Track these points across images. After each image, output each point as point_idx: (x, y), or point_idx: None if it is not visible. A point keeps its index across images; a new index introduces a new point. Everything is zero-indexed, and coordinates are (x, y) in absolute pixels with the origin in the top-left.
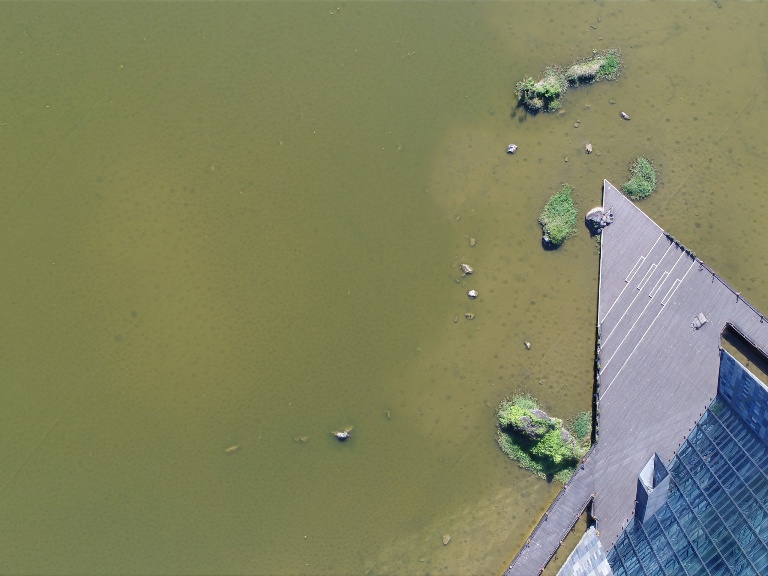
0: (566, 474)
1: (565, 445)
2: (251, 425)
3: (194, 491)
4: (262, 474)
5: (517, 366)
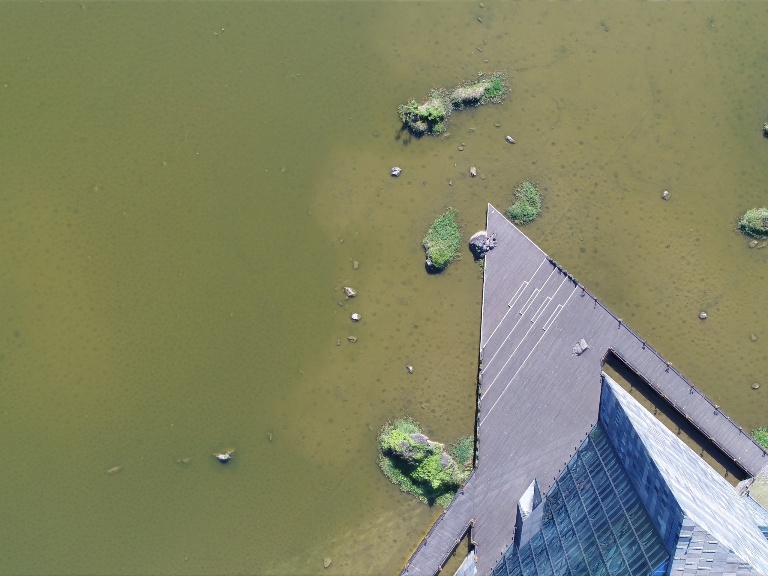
0: (447, 498)
1: (444, 470)
2: (133, 446)
3: (76, 511)
4: (144, 495)
5: (399, 390)
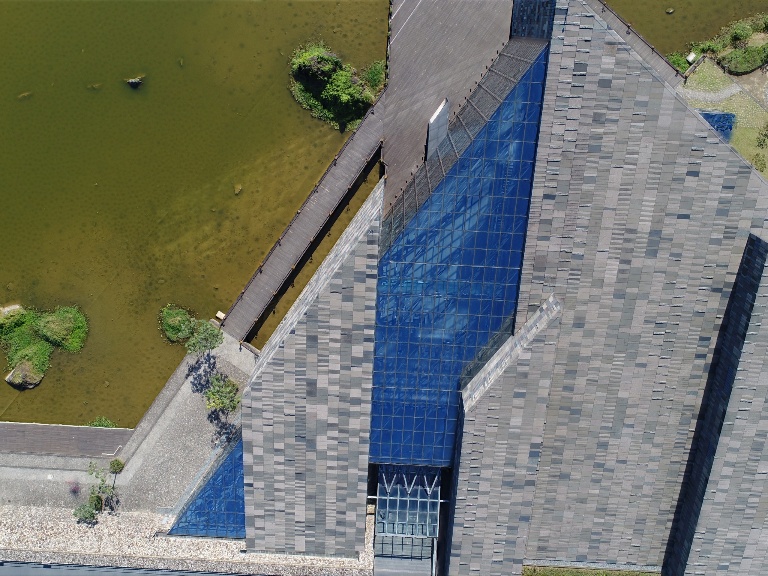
0: None
1: (353, 86)
2: (44, 72)
3: None
4: (54, 121)
5: (311, 14)
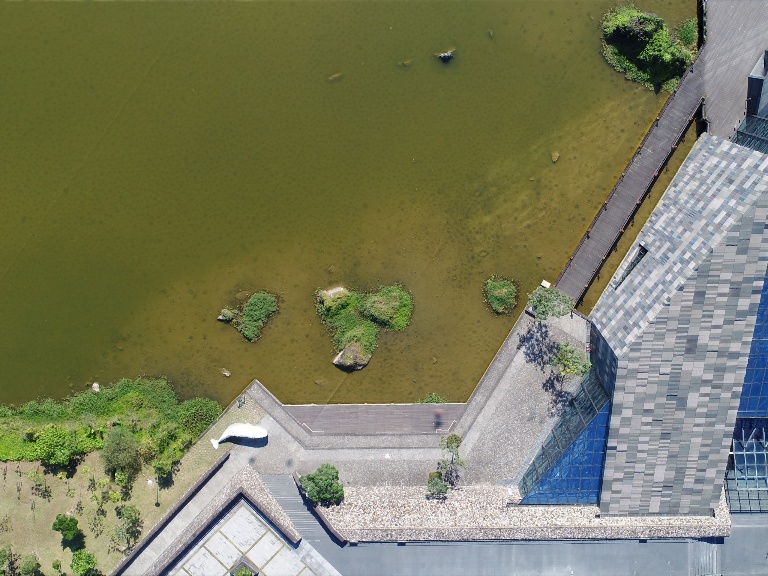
0: (674, 83)
1: (674, 45)
2: (353, 52)
3: (299, 122)
4: (366, 101)
5: None
